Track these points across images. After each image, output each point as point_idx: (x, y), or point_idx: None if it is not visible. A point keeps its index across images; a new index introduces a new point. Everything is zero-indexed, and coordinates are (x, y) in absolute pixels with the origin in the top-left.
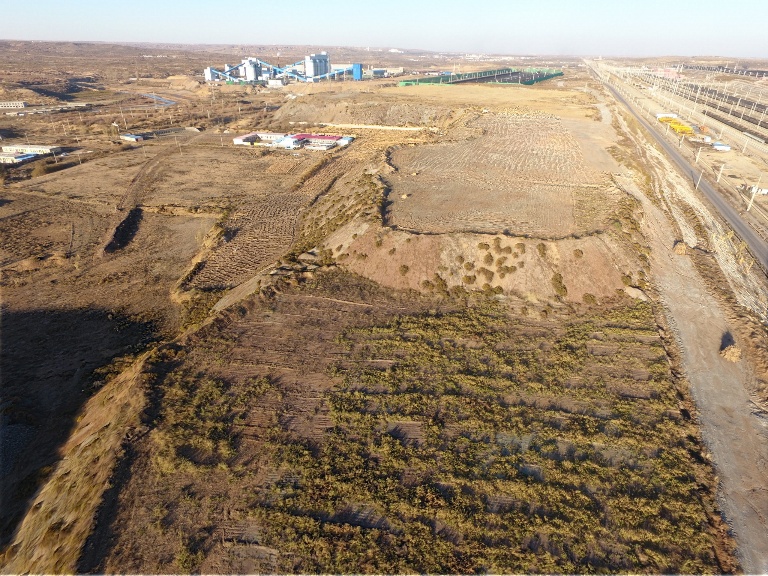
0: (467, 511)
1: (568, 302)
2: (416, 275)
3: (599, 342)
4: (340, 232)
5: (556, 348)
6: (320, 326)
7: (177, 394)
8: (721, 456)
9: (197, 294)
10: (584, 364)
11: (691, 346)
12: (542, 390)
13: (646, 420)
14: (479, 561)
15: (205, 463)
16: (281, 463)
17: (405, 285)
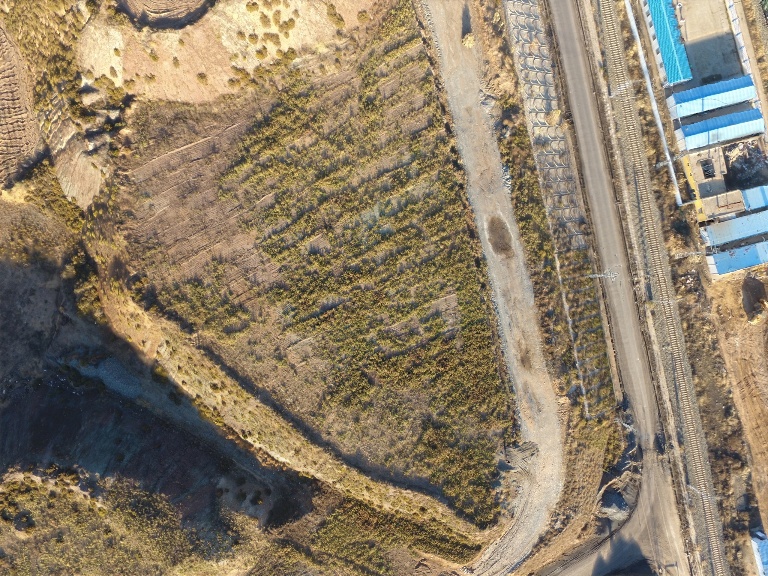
0: (370, 272)
1: (349, 32)
2: (217, 79)
3: (386, 79)
4: (92, 48)
5: (362, 108)
6: (197, 190)
7: (182, 307)
8: (467, 158)
9: (28, 186)
10: (384, 115)
11: (444, 43)
12: (369, 161)
13: (429, 150)
14: (385, 290)
15: (243, 328)
16: (276, 303)
17: (215, 93)
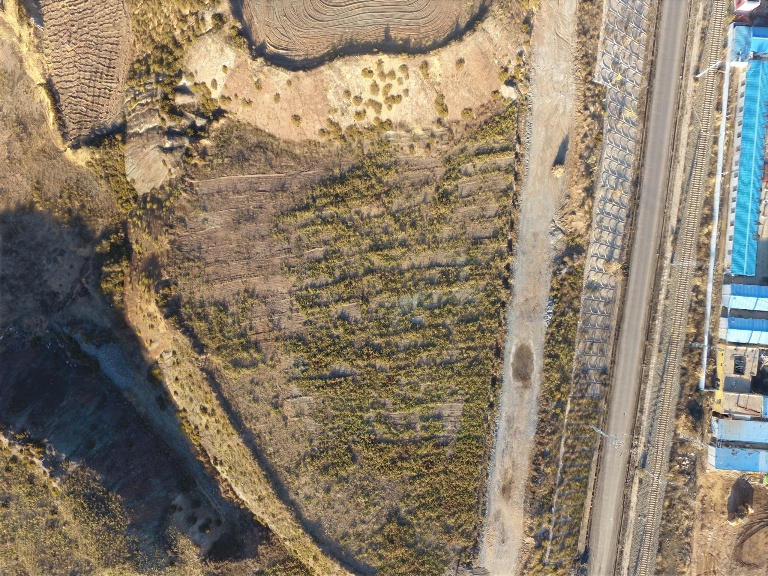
0: (389, 355)
1: (449, 123)
2: (310, 125)
3: (468, 179)
4: (202, 56)
5: (436, 198)
6: (254, 220)
7: (201, 326)
8: (518, 279)
9: (94, 154)
10: (454, 212)
11: (534, 165)
12: (425, 250)
13: (485, 260)
14: (397, 378)
15: (251, 365)
16: (290, 353)
17: (303, 136)
